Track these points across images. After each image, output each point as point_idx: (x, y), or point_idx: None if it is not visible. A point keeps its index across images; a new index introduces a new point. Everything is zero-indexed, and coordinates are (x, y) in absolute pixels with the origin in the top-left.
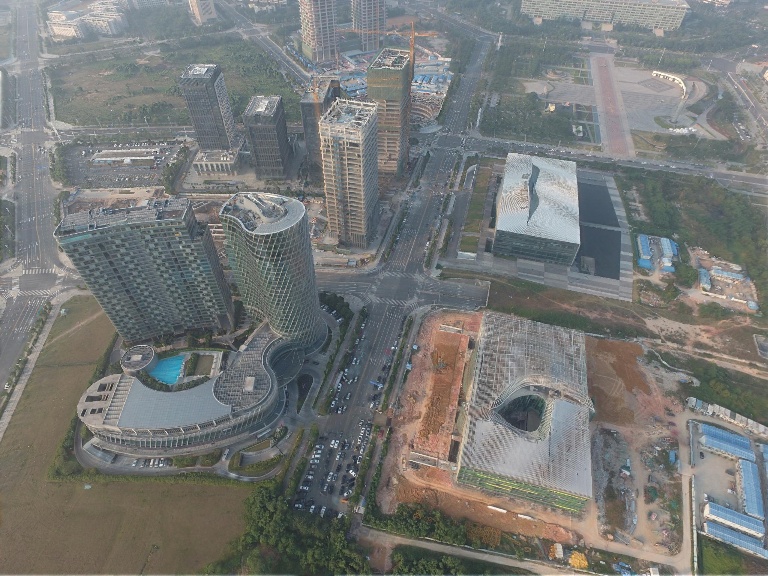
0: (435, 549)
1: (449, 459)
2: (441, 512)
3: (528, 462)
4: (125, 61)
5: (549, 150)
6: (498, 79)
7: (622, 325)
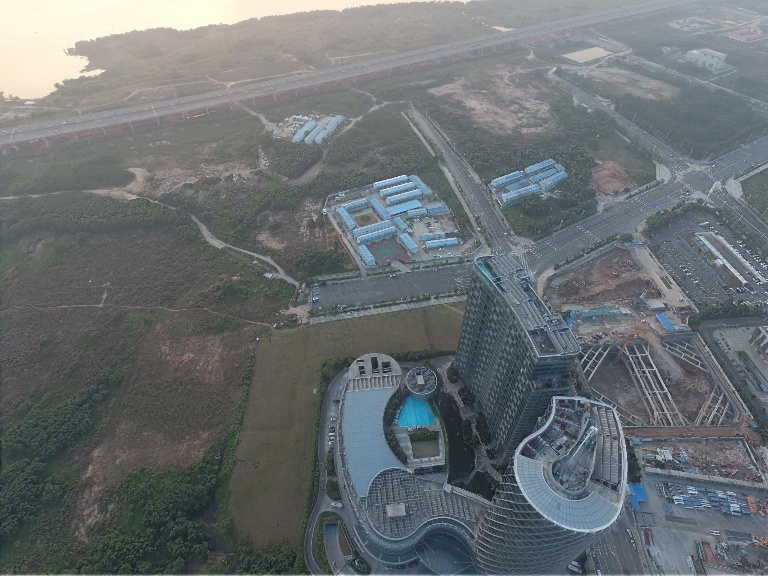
0: None
1: None
2: None
3: None
4: None
5: None
6: None
7: None
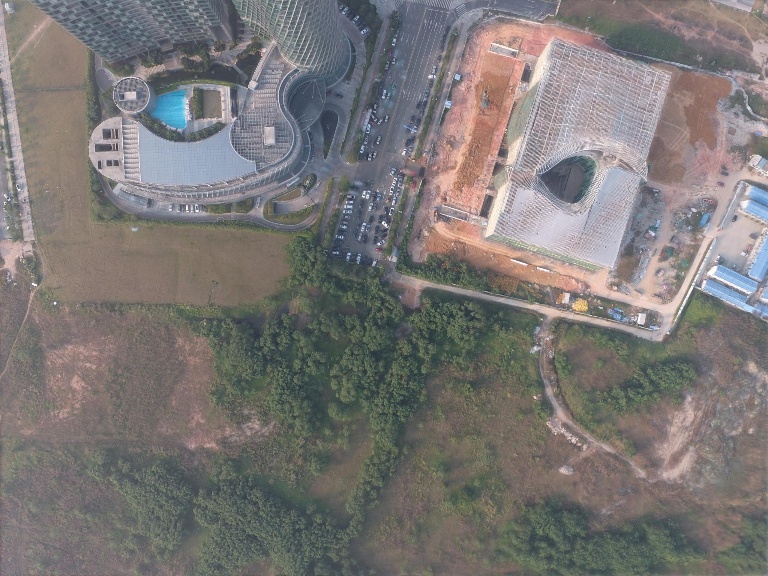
0: (458, 292)
1: (481, 214)
2: (467, 265)
3: (561, 234)
4: None
5: None
6: None
7: (721, 51)
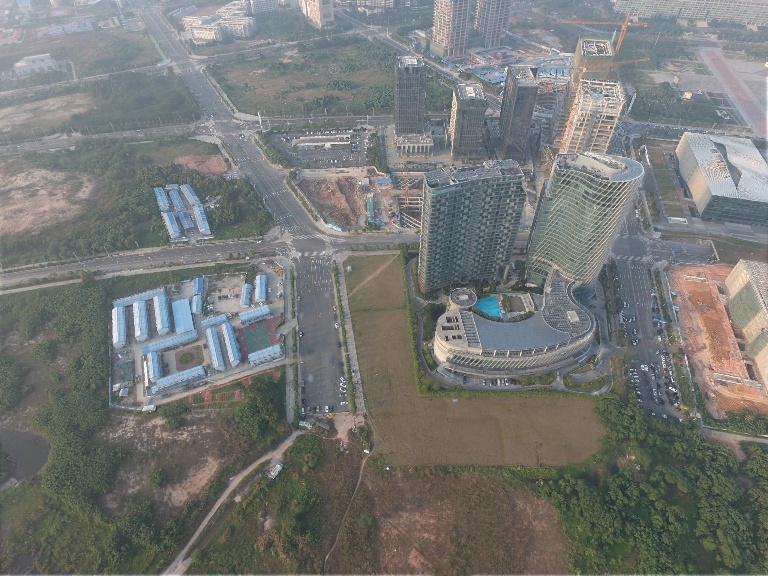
0: None
1: (750, 378)
2: None
3: None
4: (270, 60)
5: (703, 132)
6: (625, 71)
7: None
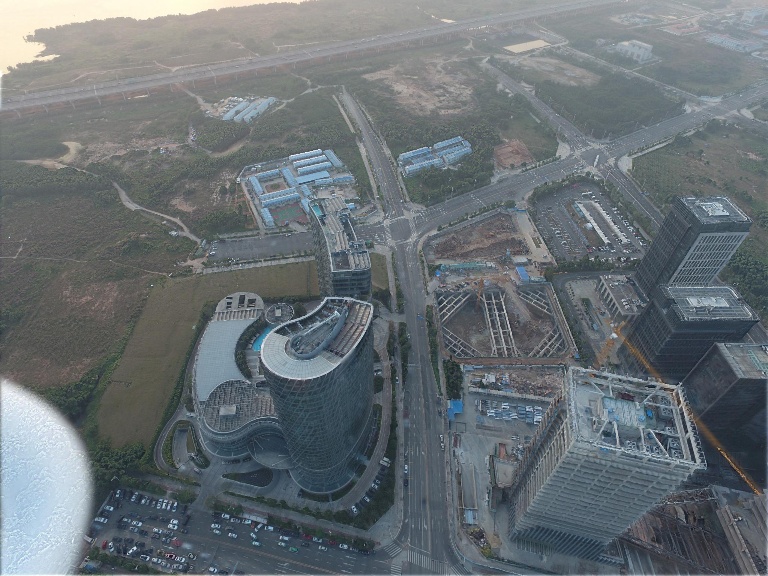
0: None
1: None
2: None
3: None
4: None
5: None
6: None
7: None
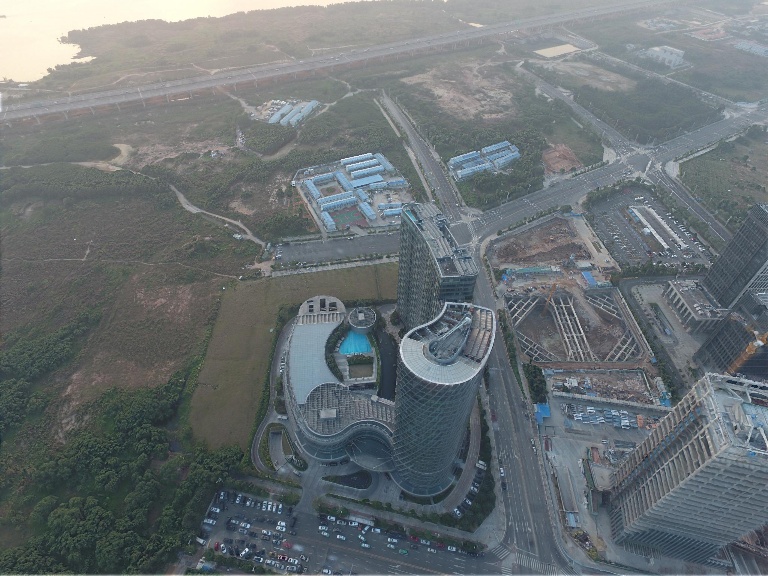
0: None
1: None
2: None
3: None
4: None
5: None
6: None
7: None
